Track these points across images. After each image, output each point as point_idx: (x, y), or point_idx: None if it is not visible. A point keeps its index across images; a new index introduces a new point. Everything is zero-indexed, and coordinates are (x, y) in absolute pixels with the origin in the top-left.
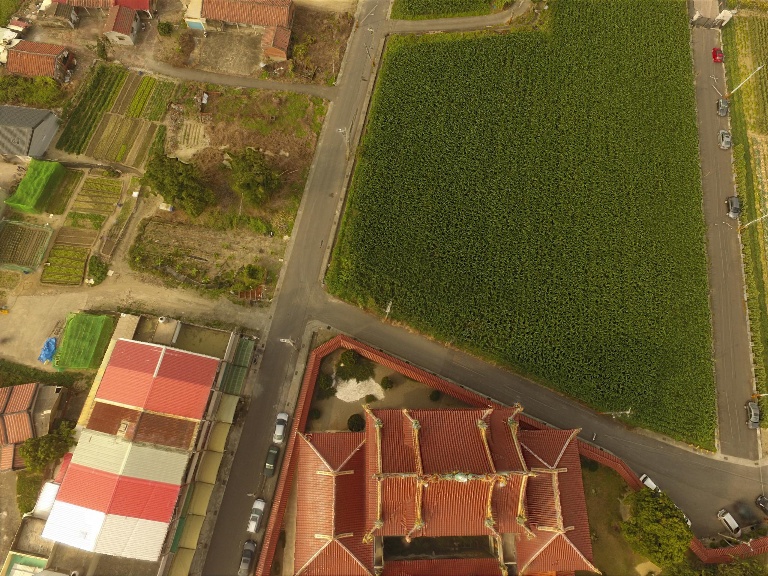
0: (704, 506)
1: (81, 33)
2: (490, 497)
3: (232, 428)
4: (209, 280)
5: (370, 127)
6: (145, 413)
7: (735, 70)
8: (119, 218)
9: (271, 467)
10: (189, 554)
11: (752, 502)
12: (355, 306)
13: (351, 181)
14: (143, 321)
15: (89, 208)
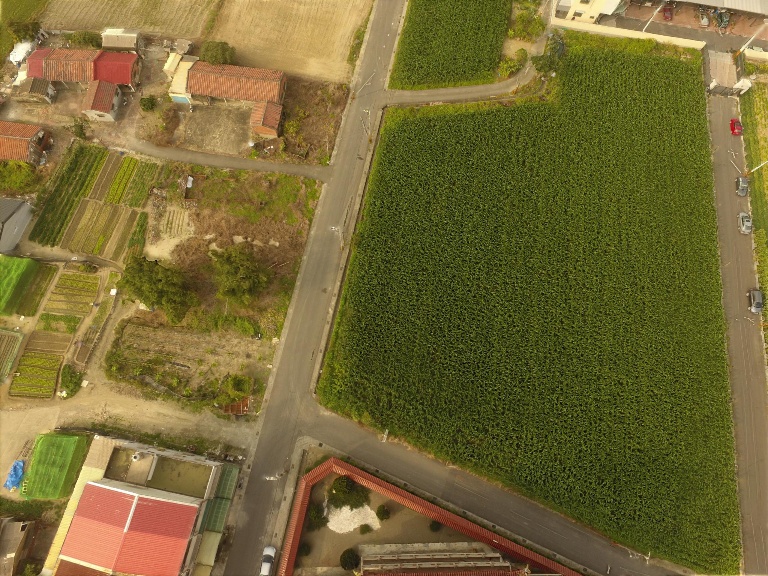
0: None
1: (59, 108)
2: None
3: (214, 565)
4: (191, 392)
5: (366, 213)
6: (114, 575)
7: (754, 143)
8: (95, 320)
9: None
10: None
11: None
12: (349, 419)
13: (345, 274)
14: (116, 452)
15: (63, 308)
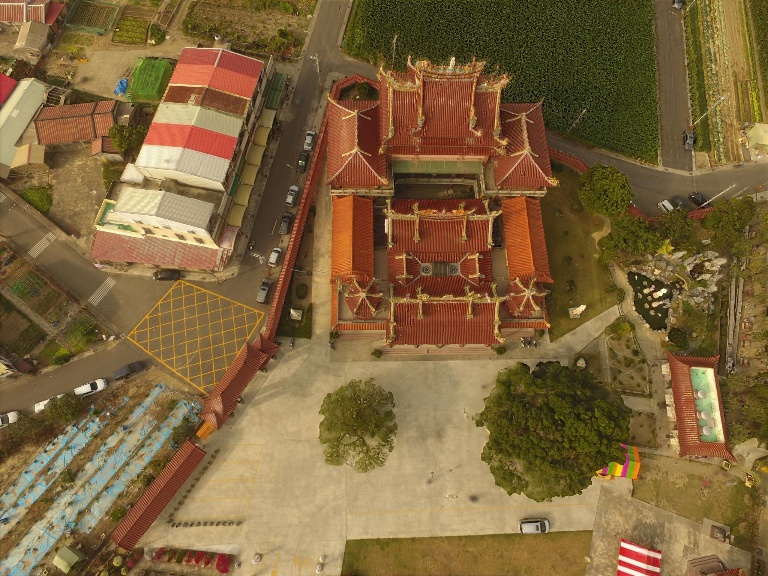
0: (648, 200)
1: None
2: (473, 101)
3: (271, 141)
4: (248, 41)
5: None
6: (209, 89)
7: None
8: None
9: (303, 164)
10: (242, 207)
11: (686, 198)
12: (367, 63)
13: None
14: None
15: None
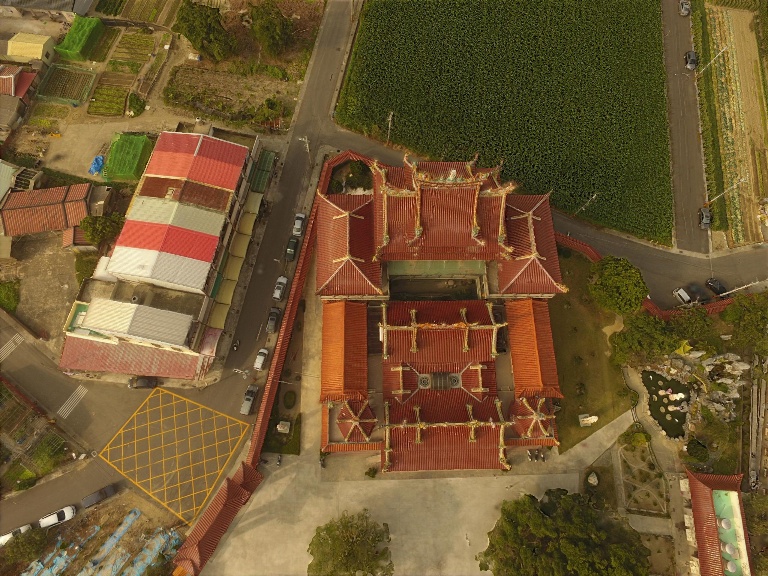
0: (662, 287)
1: None
2: (475, 209)
3: (257, 225)
4: (234, 112)
5: None
6: (188, 181)
7: None
8: (153, 65)
9: (292, 252)
10: (225, 307)
11: (703, 284)
12: (361, 134)
13: (355, 38)
14: (181, 129)
15: (127, 57)
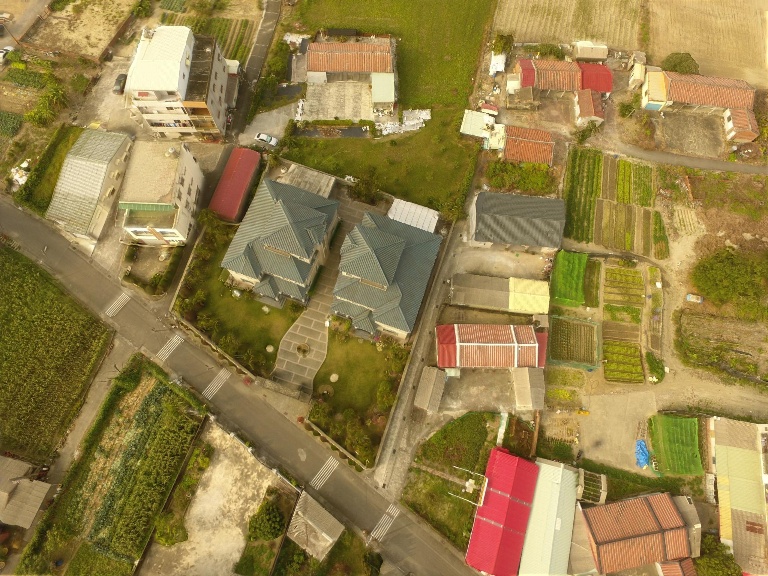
0: None
1: (543, 115)
2: None
3: None
4: None
5: None
6: None
7: None
8: (653, 311)
9: None
10: None
11: None
12: None
13: None
14: None
15: (620, 300)
